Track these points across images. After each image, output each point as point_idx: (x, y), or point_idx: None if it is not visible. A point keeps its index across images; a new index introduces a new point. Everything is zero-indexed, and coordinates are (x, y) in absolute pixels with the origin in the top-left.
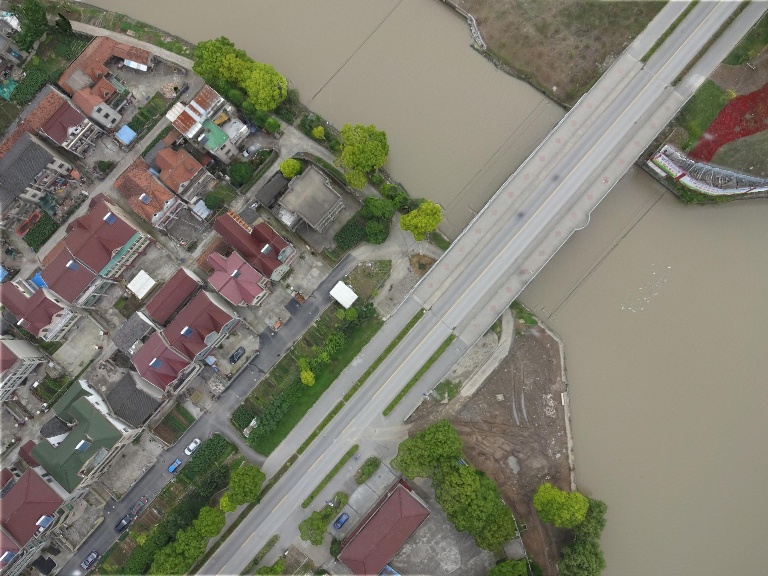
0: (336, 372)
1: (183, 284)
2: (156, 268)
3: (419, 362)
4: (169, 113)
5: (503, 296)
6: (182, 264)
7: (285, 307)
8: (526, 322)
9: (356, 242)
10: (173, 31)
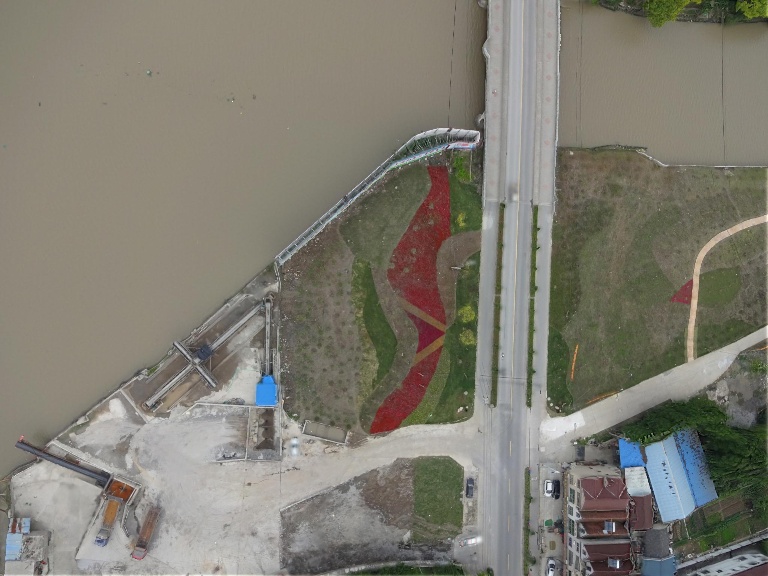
0: None
1: None
2: None
3: None
4: None
5: None
6: None
7: None
8: None
9: None
10: None
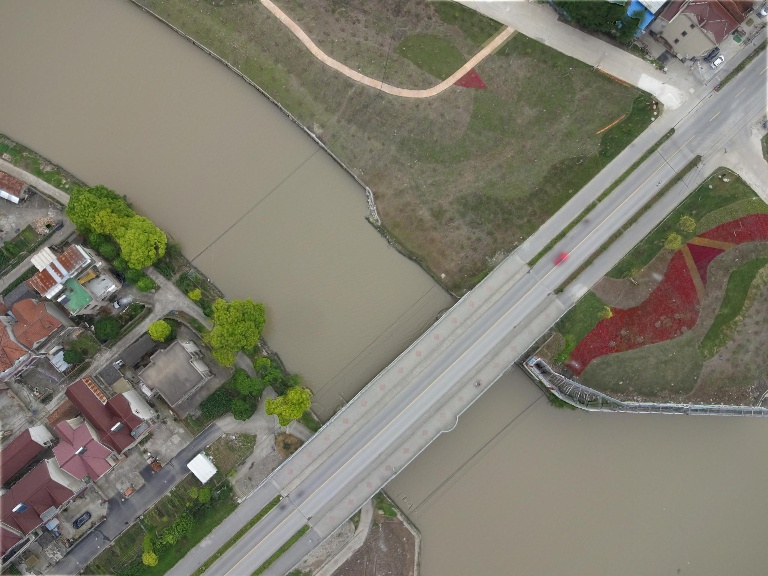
0: (183, 551)
1: (26, 448)
2: (5, 417)
3: (270, 549)
4: (34, 258)
5: (362, 490)
6: (34, 416)
7: (139, 473)
8: (385, 513)
9: (222, 413)
10: (55, 159)
